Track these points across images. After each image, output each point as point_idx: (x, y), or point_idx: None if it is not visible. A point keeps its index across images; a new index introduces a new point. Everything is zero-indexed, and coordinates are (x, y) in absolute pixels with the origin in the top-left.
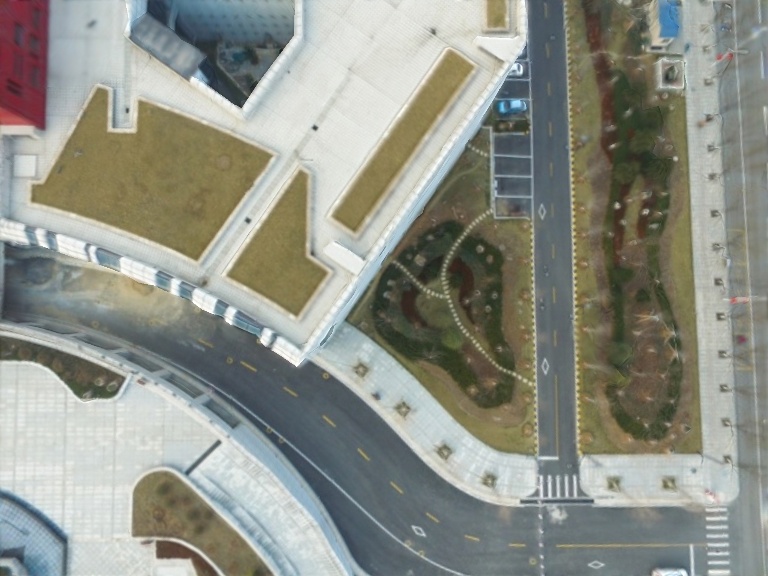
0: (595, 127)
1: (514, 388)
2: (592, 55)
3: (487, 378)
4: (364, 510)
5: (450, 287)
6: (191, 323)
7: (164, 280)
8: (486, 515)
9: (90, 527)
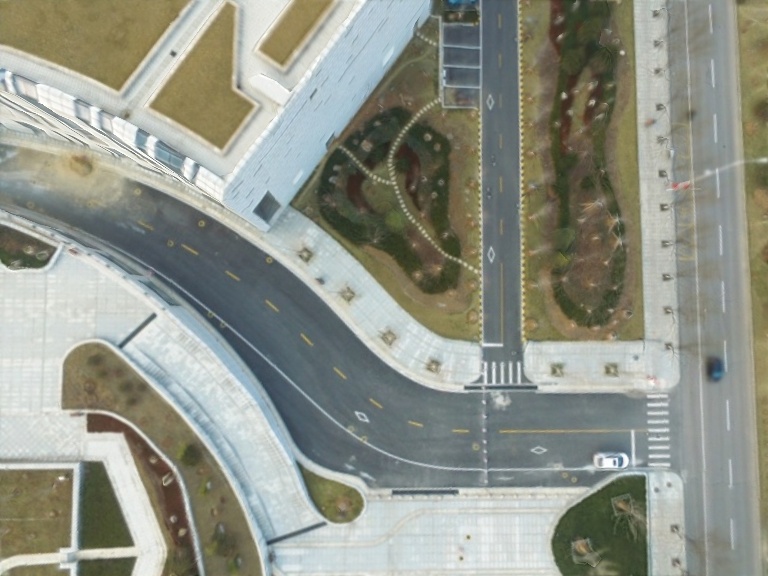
0: (544, 20)
1: (459, 275)
2: None
3: (432, 264)
4: (307, 395)
5: (396, 172)
6: (131, 205)
7: (83, 107)
8: (430, 401)
9: (18, 400)
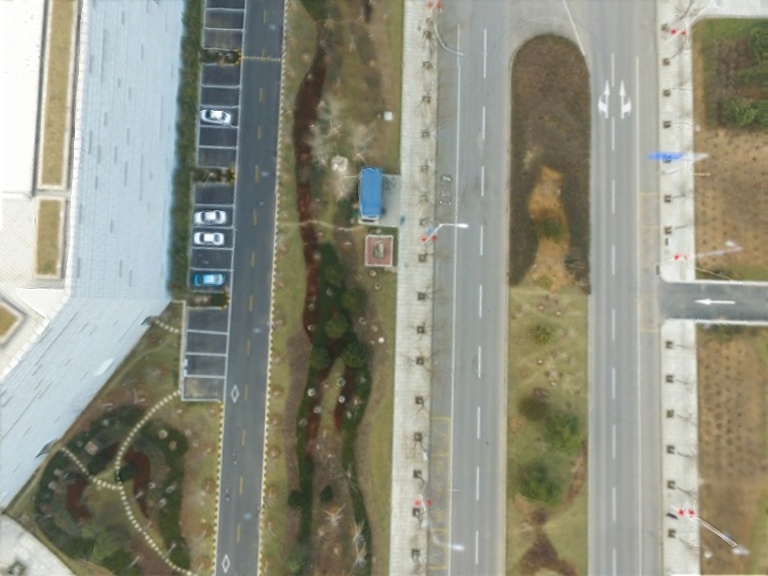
0: (299, 303)
1: None
2: (301, 224)
3: None
4: None
5: (120, 479)
6: None
7: None
8: None
9: None
